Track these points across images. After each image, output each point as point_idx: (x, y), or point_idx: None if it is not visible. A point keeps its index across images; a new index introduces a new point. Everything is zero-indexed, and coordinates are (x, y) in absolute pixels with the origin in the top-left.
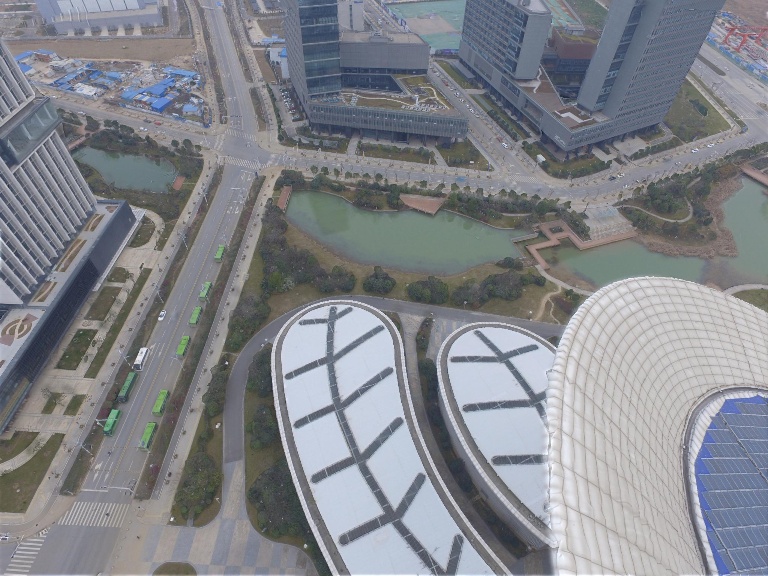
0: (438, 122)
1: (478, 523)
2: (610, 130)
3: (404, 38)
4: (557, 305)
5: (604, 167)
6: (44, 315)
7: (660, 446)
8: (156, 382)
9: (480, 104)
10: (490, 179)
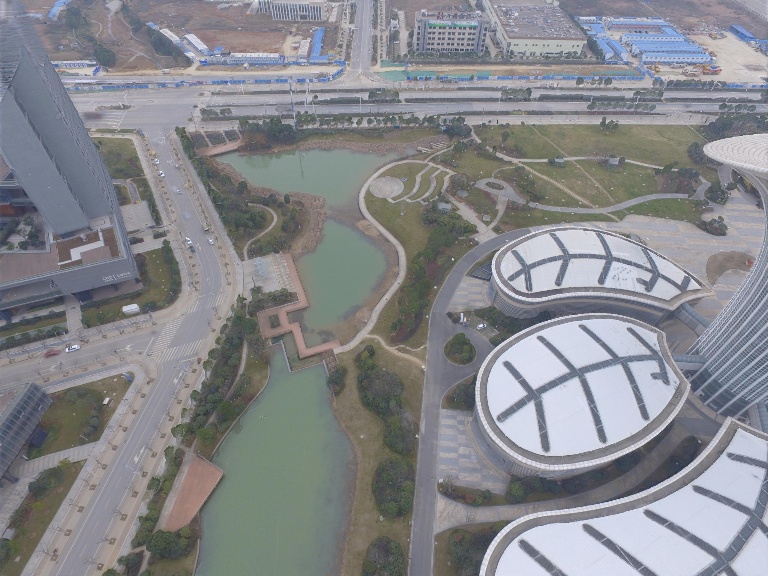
0: (2, 439)
1: (663, 450)
2: None
3: None
4: (402, 342)
5: None
6: None
7: None
8: None
9: None
10: (154, 381)
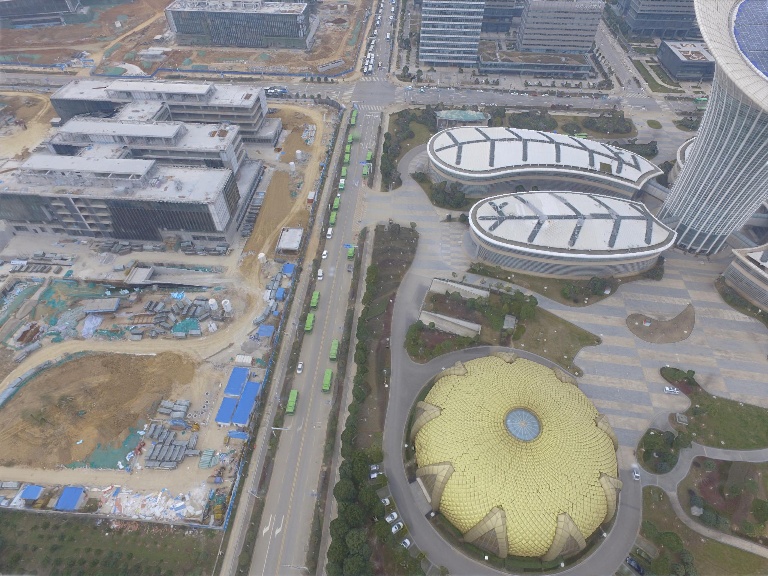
0: None
1: None
2: None
3: None
4: None
5: None
6: None
7: None
8: None
9: None
10: None
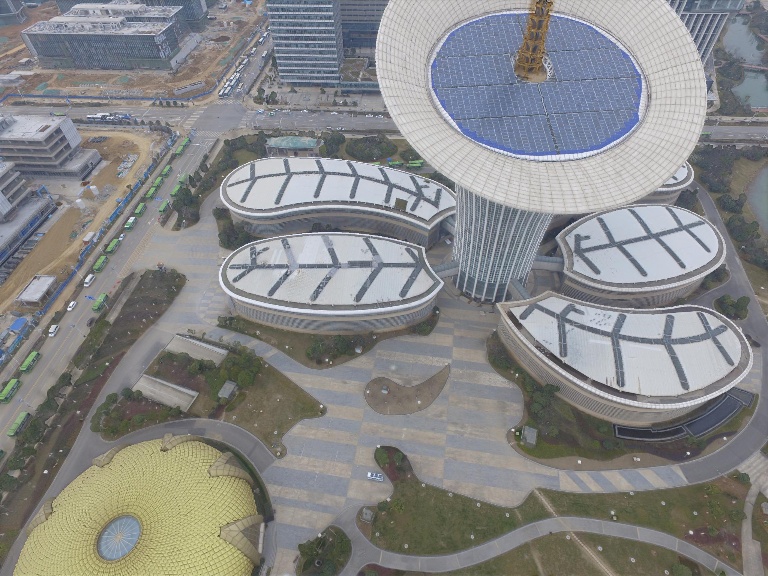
0: None
1: None
2: None
3: None
4: None
5: None
6: None
7: (590, 1)
8: None
9: None
10: None
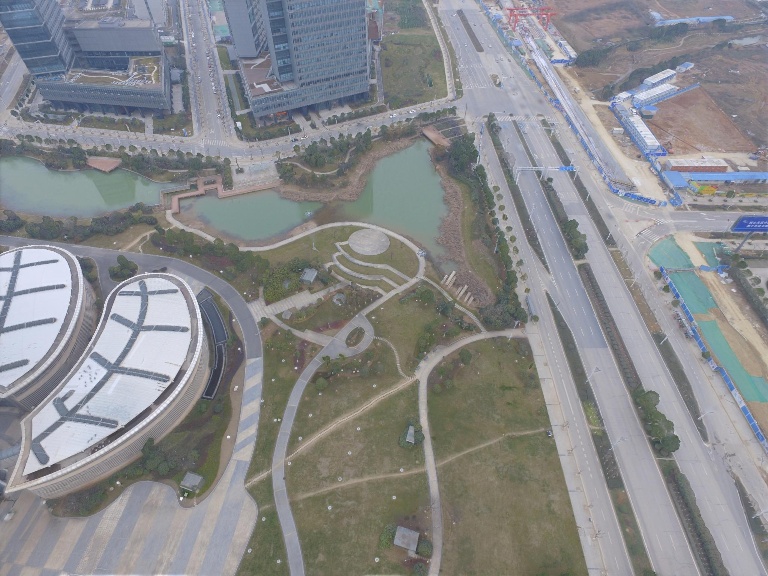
0: (140, 95)
1: None
2: (301, 98)
3: (136, 23)
4: (150, 239)
5: (293, 131)
6: None
7: None
8: None
9: (226, 82)
10: (182, 143)
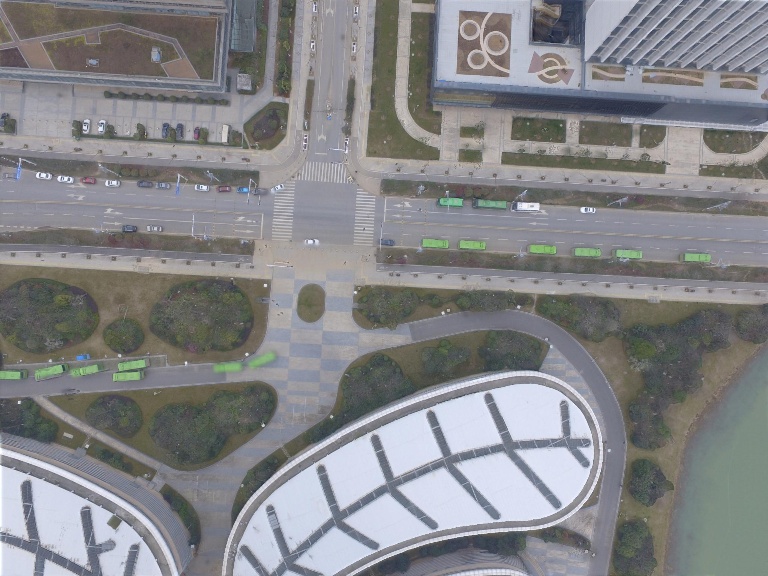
0: None
1: None
2: None
3: None
4: None
5: None
6: (571, 91)
7: None
8: (498, 230)
9: None
10: None
